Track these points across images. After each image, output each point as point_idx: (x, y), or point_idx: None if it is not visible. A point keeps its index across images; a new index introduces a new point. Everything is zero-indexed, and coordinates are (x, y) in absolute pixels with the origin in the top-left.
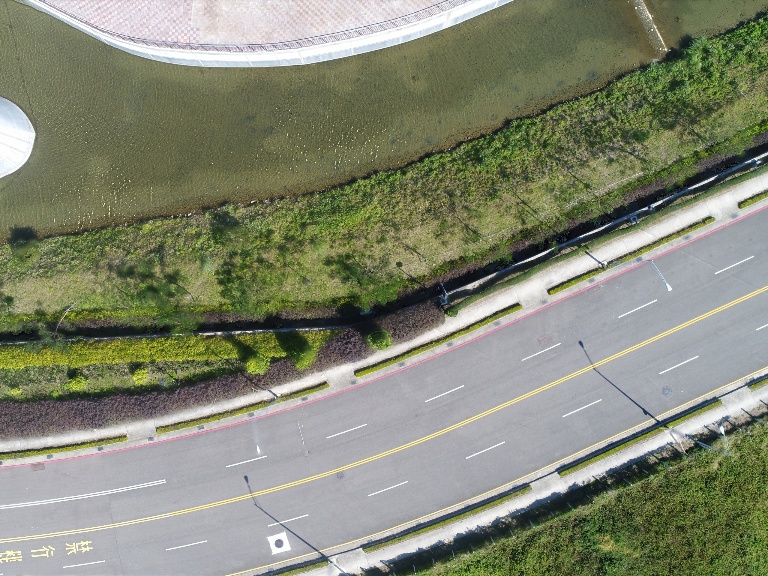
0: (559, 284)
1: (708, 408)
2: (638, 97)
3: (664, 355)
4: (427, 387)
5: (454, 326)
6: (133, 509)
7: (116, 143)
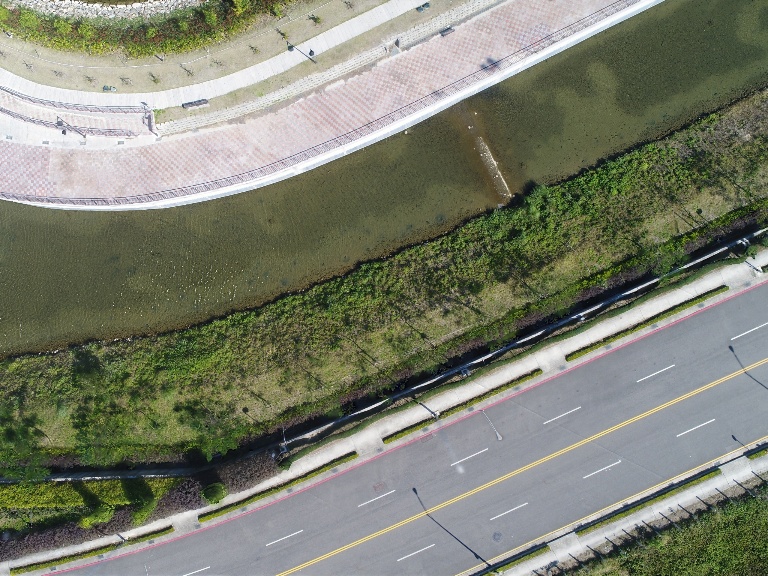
0: (394, 433)
1: (536, 554)
2: (479, 245)
3: (495, 502)
4: (268, 531)
5: (293, 473)
6: None
7: None
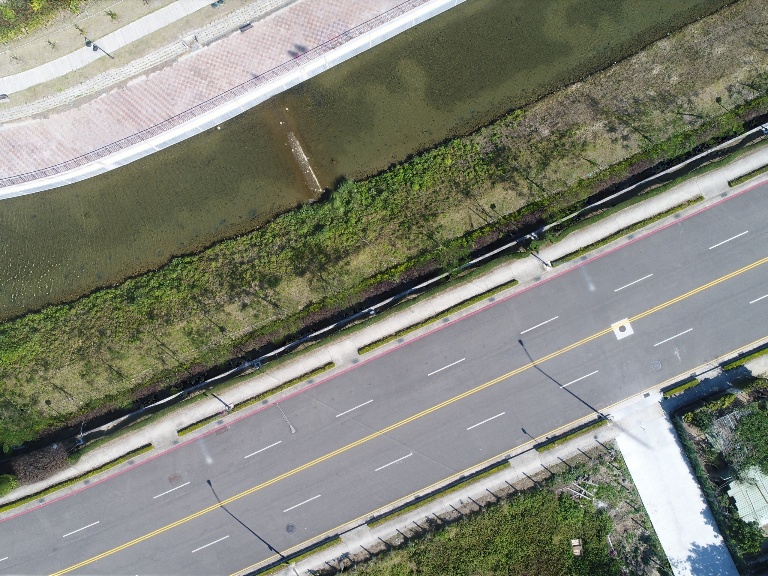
0: (189, 426)
1: (327, 546)
2: (284, 240)
3: (288, 494)
4: (65, 523)
5: (90, 465)
6: None
7: None
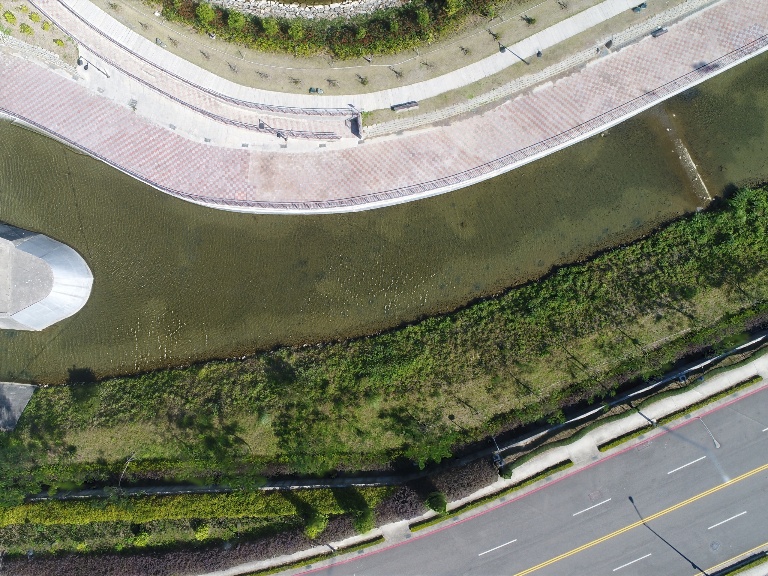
0: (609, 441)
1: (756, 563)
2: (684, 249)
3: (713, 510)
4: (480, 541)
5: (506, 481)
6: None
7: (172, 287)
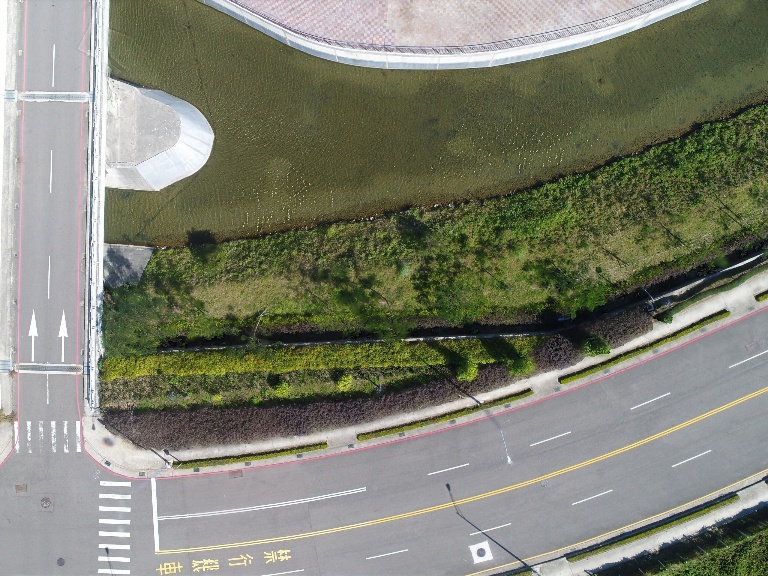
0: (767, 290)
1: None
2: None
3: None
4: (632, 394)
5: (660, 333)
6: (333, 517)
7: (296, 146)
